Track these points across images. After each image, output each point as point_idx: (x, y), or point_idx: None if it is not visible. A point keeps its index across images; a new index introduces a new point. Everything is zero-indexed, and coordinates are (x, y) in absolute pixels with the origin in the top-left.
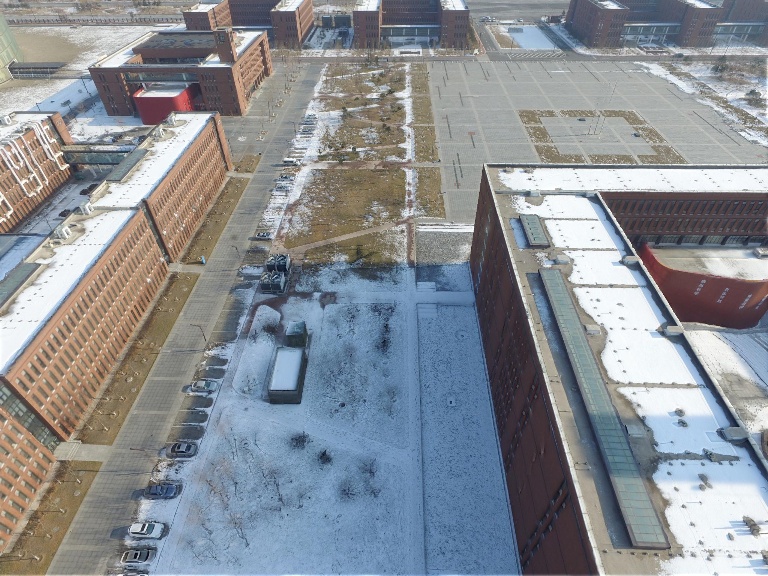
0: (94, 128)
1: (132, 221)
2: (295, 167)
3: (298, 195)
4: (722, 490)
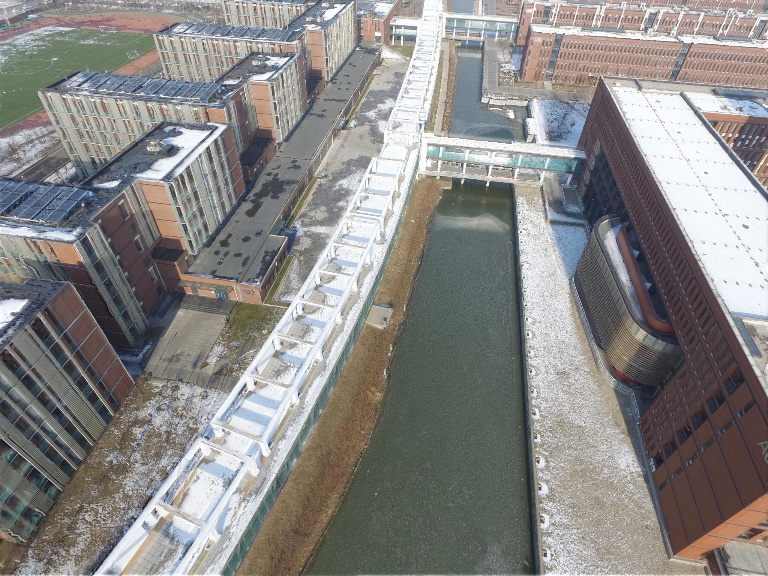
0: None
1: None
2: None
3: None
4: None
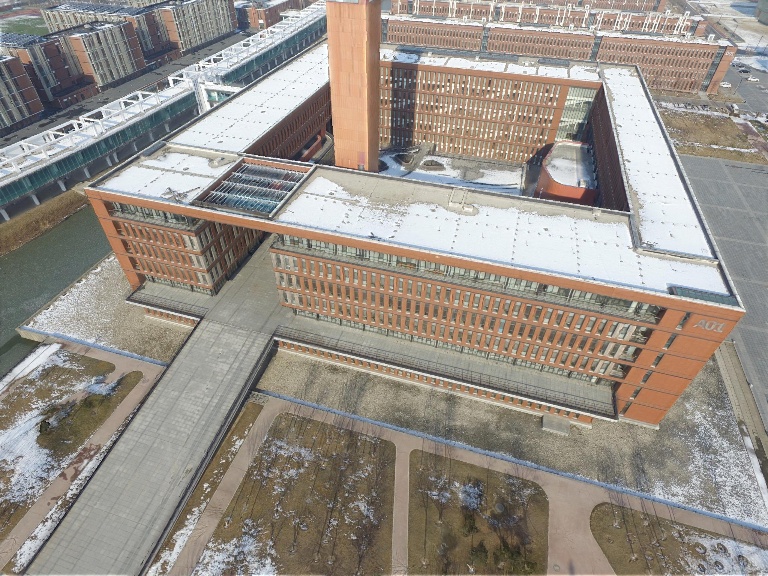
0: (753, 61)
1: (584, 36)
2: (729, 112)
3: (681, 110)
4: (406, 59)
